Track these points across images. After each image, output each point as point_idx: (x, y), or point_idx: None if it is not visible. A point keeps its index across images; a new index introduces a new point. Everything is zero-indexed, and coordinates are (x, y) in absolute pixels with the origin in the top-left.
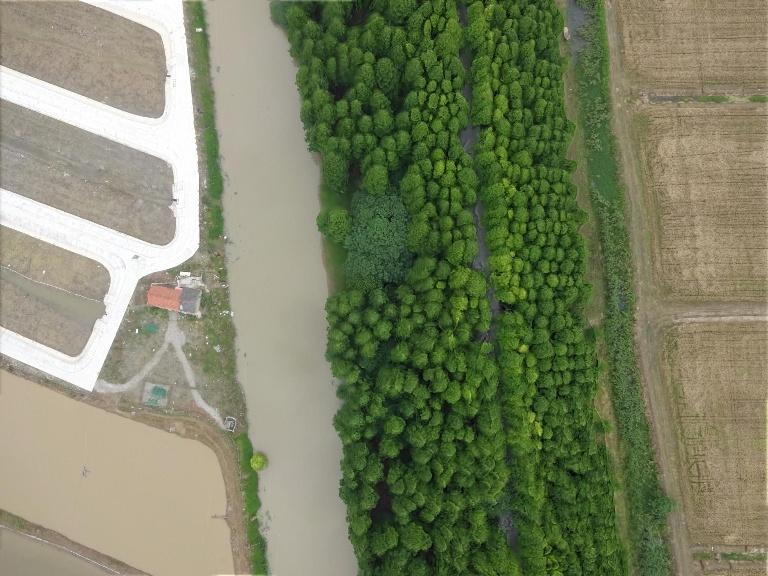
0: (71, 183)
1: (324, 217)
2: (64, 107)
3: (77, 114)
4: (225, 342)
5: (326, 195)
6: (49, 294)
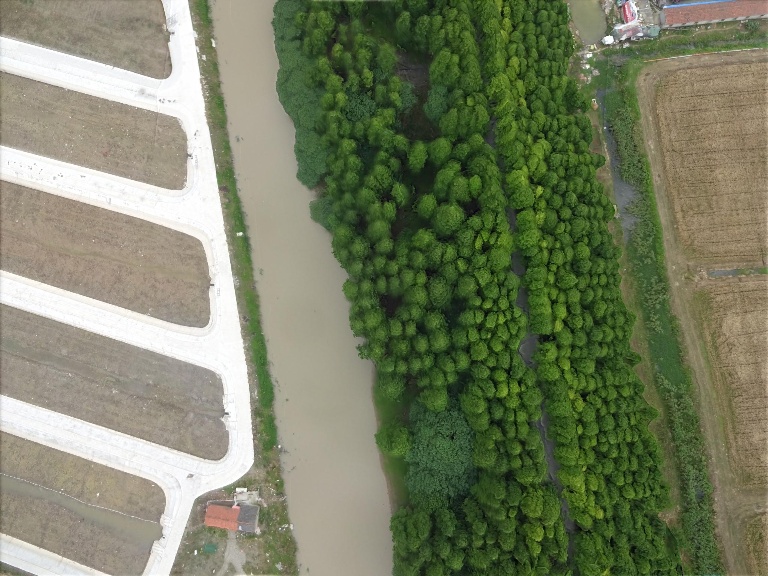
0: (120, 400)
1: (383, 435)
2: (109, 324)
3: (123, 330)
4: (286, 559)
5: (380, 397)
6: (104, 517)
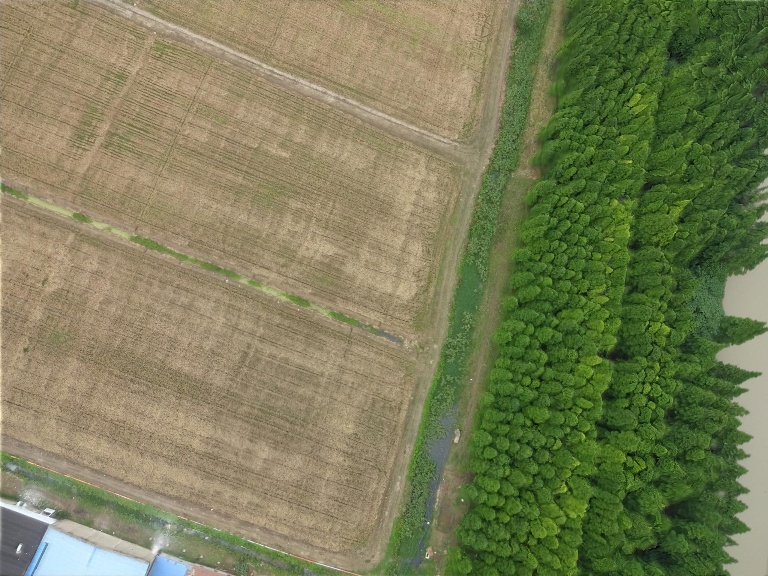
0: None
1: None
2: None
3: None
4: None
5: None
6: None
